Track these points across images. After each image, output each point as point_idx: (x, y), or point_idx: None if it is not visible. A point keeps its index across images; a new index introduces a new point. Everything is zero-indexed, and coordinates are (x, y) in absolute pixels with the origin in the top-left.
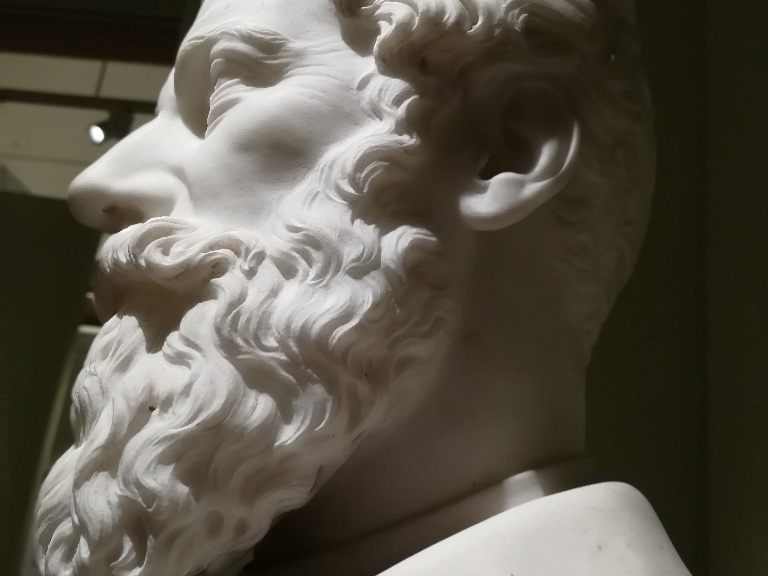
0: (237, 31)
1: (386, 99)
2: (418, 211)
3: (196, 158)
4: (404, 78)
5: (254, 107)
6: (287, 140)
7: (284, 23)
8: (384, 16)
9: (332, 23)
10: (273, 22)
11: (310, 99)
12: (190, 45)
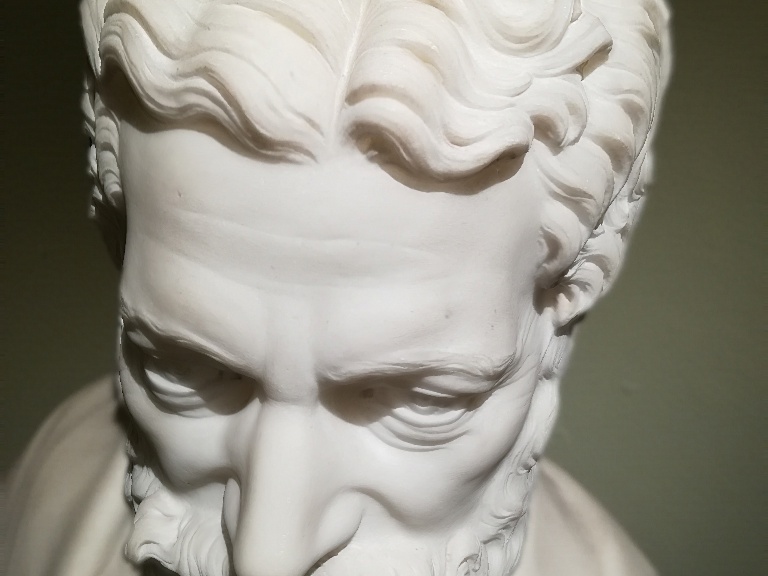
0: None
1: None
2: None
3: (416, 496)
4: None
5: (489, 443)
6: None
7: None
8: (580, 283)
9: None
10: None
11: None
12: (397, 371)
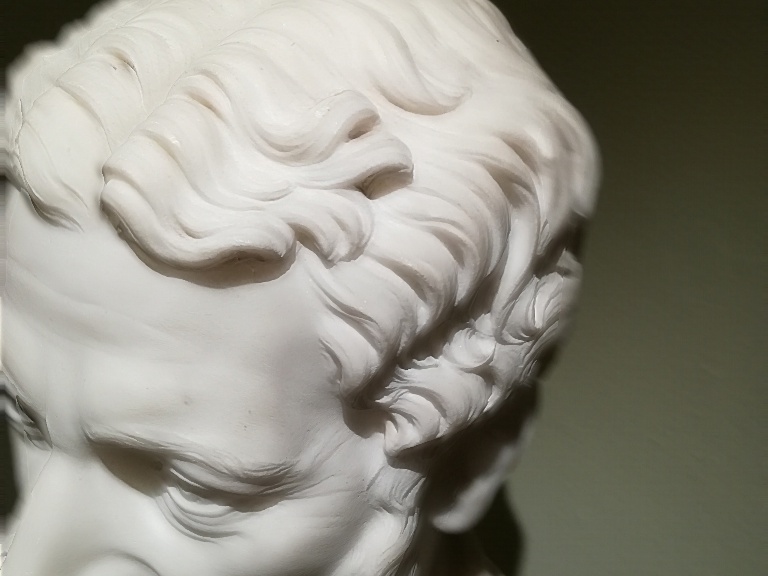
0: (229, 471)
1: (397, 497)
2: (407, 557)
3: None
4: (416, 470)
5: (265, 553)
6: (304, 574)
7: (284, 440)
8: (403, 414)
9: (333, 406)
10: (273, 447)
11: (326, 530)
12: (134, 444)
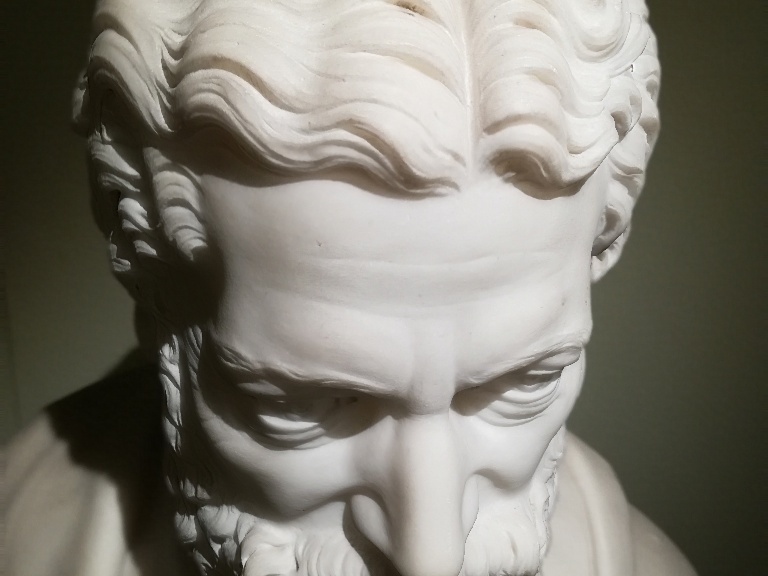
0: None
1: None
2: None
3: None
4: None
5: None
6: None
7: None
8: None
9: None
10: None
11: None
12: None
